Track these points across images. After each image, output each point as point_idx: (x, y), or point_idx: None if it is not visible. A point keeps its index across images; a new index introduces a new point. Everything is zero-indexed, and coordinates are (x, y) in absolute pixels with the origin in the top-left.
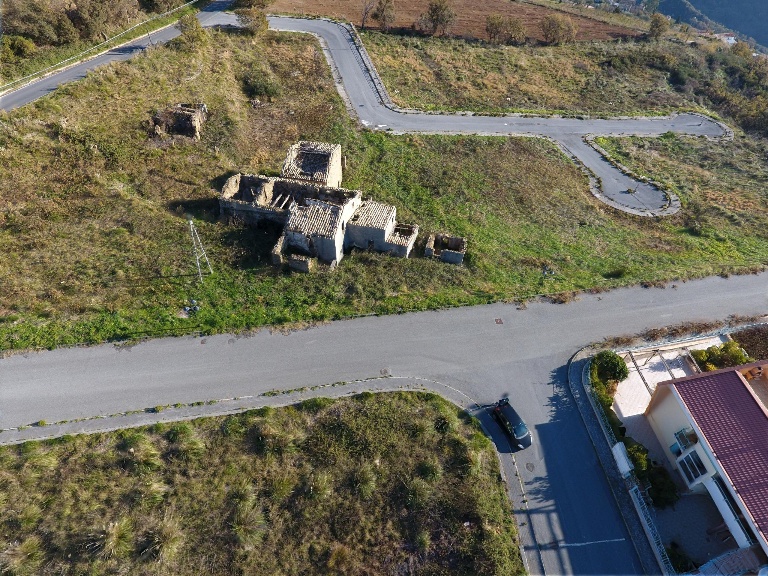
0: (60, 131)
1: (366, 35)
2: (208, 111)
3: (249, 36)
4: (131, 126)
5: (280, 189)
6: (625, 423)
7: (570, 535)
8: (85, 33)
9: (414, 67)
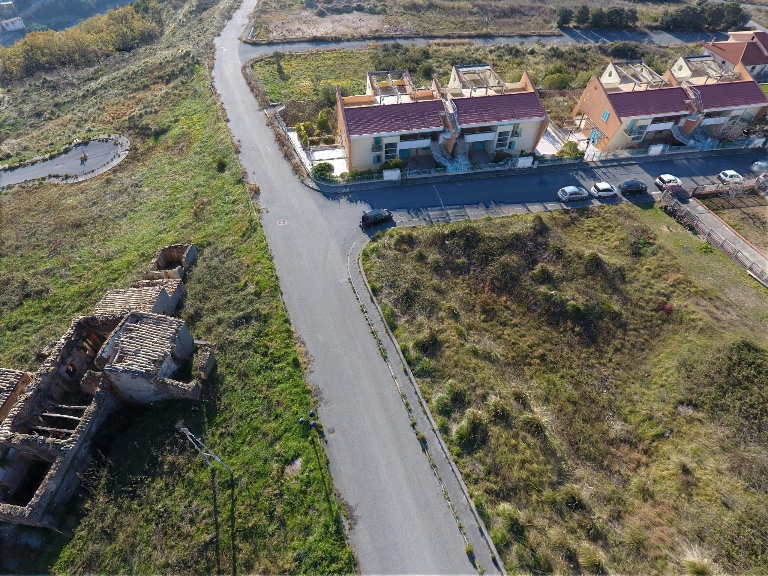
0: None
1: None
2: None
3: None
4: None
5: None
6: None
7: (438, 204)
8: None
9: None
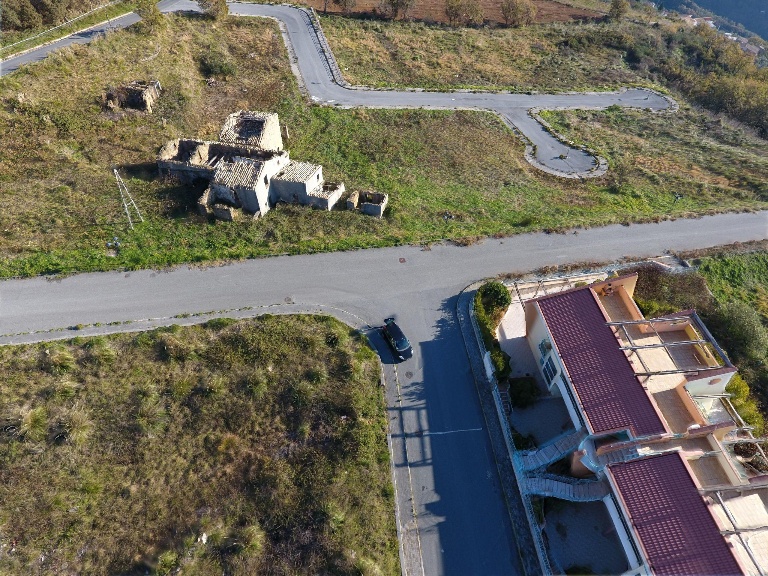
0: (17, 105)
1: (327, 19)
2: (162, 88)
3: (209, 21)
4: (86, 101)
5: (216, 152)
6: (507, 344)
7: (434, 426)
8: (49, 19)
9: (371, 48)
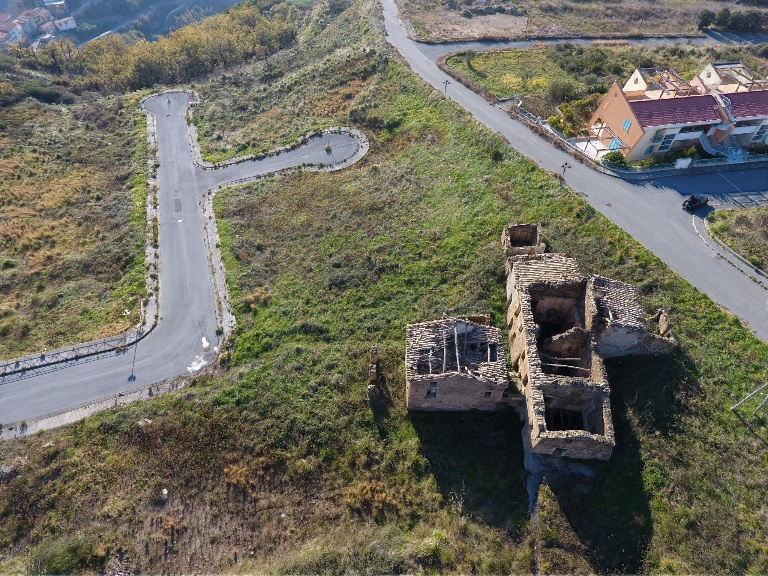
0: None
1: None
2: None
3: None
4: None
5: None
6: None
7: (735, 190)
8: None
9: None
